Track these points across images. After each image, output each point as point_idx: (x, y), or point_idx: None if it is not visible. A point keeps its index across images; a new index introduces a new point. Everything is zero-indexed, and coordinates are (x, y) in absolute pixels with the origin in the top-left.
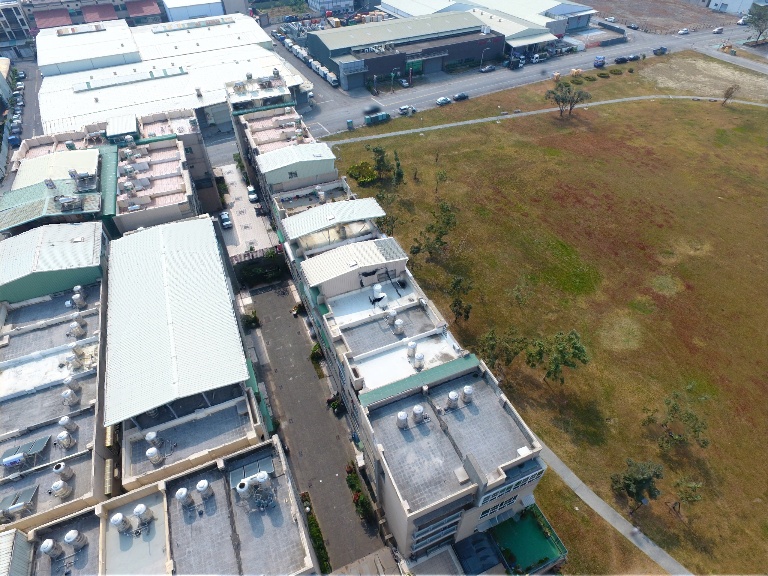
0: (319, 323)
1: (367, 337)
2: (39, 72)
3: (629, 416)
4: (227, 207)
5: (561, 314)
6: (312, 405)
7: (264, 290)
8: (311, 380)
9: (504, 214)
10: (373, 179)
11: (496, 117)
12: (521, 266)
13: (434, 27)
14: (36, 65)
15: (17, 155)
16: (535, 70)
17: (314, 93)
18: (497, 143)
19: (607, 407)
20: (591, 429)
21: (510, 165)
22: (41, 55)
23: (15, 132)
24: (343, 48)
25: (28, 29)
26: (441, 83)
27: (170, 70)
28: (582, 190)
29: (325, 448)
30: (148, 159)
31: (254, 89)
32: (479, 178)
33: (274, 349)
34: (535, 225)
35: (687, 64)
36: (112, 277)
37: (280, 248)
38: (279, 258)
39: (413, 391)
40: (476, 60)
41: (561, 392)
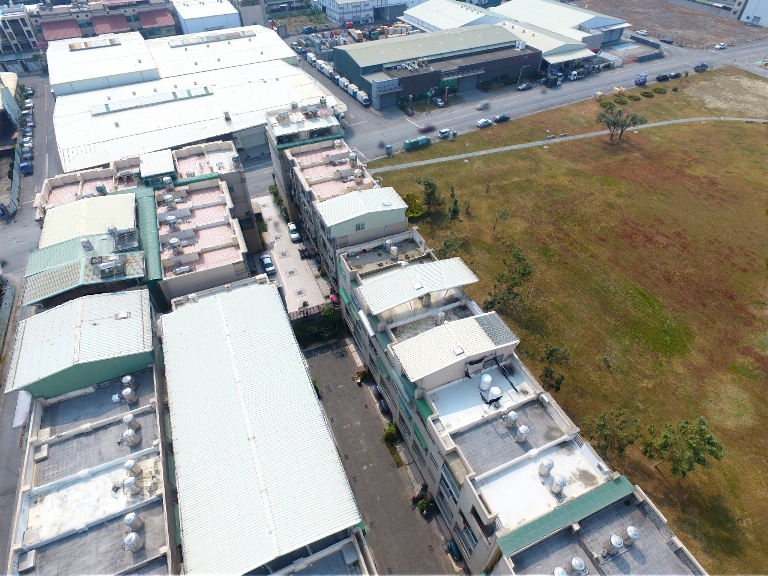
0: (409, 414)
1: (483, 446)
2: (48, 88)
3: (763, 516)
4: (267, 248)
5: (658, 381)
6: (394, 503)
7: (320, 351)
8: (388, 469)
9: (571, 256)
10: (422, 214)
11: (543, 141)
12: (601, 320)
13: (467, 42)
14: (44, 80)
15: (40, 199)
16: (574, 88)
17: (345, 113)
18: (548, 171)
19: (735, 503)
20: (723, 534)
21: (567, 197)
22: (53, 72)
23: (26, 157)
24: (374, 65)
25: (35, 41)
26: (478, 102)
27: (194, 90)
28: (650, 227)
29: (418, 563)
30: (190, 204)
31: (299, 119)
32: (536, 212)
33: (340, 428)
34: (607, 269)
35: (731, 82)
36: (170, 367)
37: (337, 303)
38: (335, 314)
39: (560, 530)
40: (512, 77)
41: (678, 483)
